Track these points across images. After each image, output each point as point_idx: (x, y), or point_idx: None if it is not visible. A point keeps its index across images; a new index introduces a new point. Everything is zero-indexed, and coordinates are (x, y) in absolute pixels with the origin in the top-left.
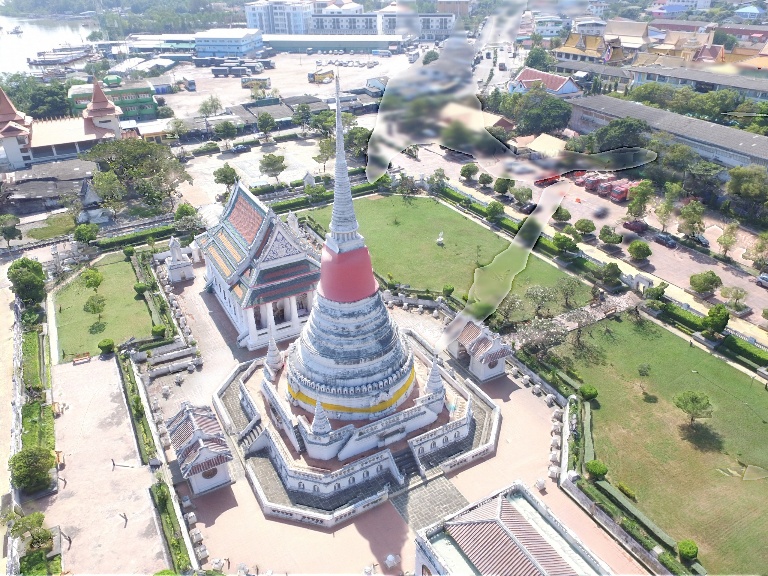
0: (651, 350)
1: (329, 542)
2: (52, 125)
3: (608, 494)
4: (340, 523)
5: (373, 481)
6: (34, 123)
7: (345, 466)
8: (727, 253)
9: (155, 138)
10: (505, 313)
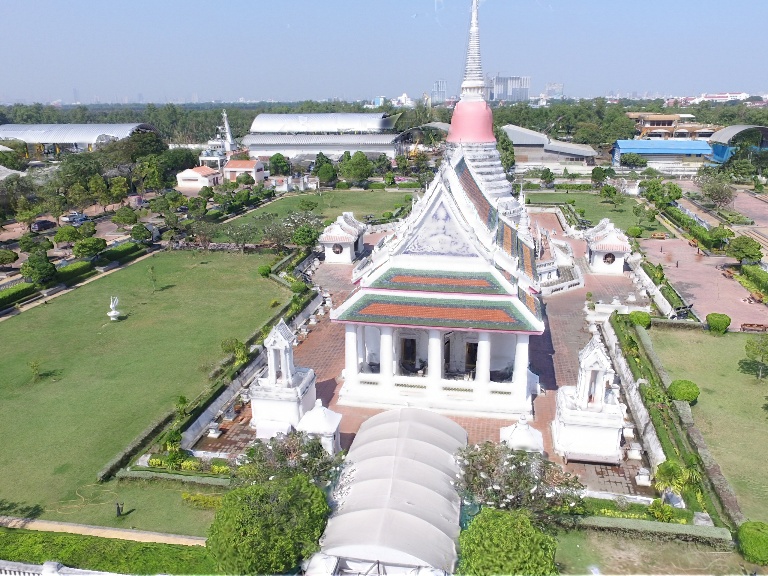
0: None
1: None
2: None
3: None
4: None
5: None
6: None
7: None
8: None
9: None
10: None
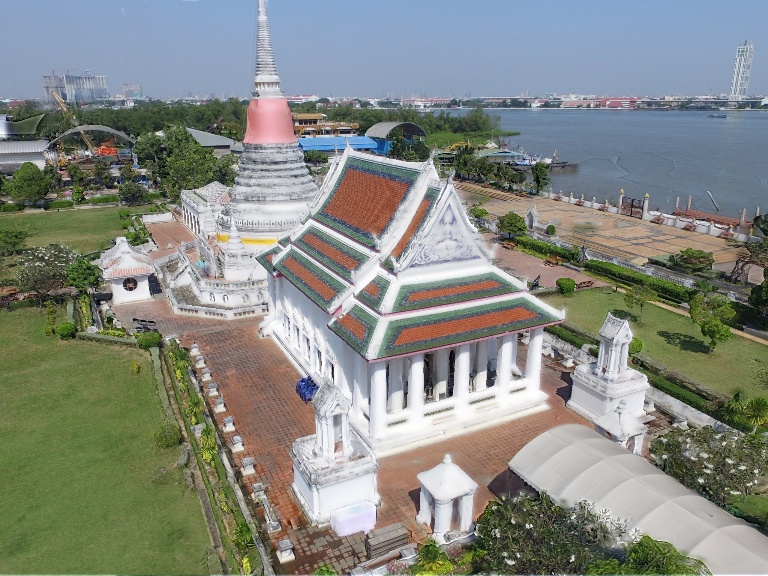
0: None
1: None
2: None
3: None
4: None
5: None
6: None
7: None
8: None
9: None
10: None
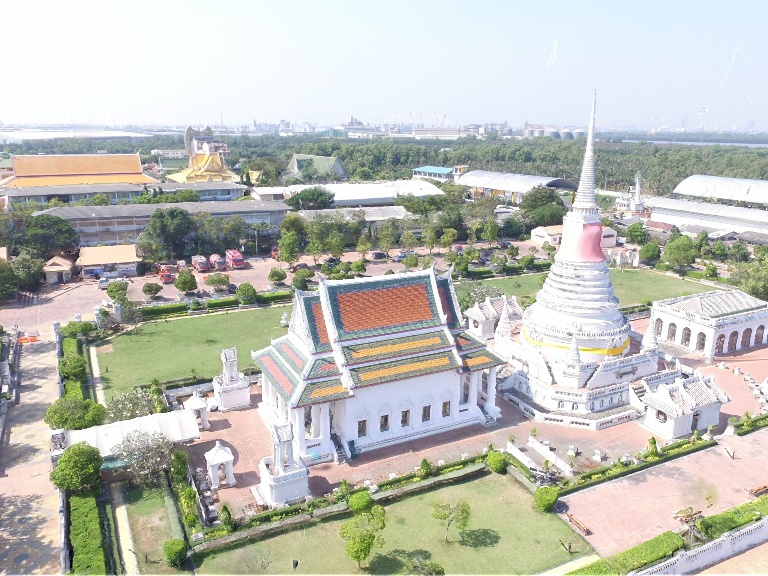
0: None
1: None
2: None
3: None
4: None
5: None
6: None
7: None
8: (365, 256)
9: None
10: None
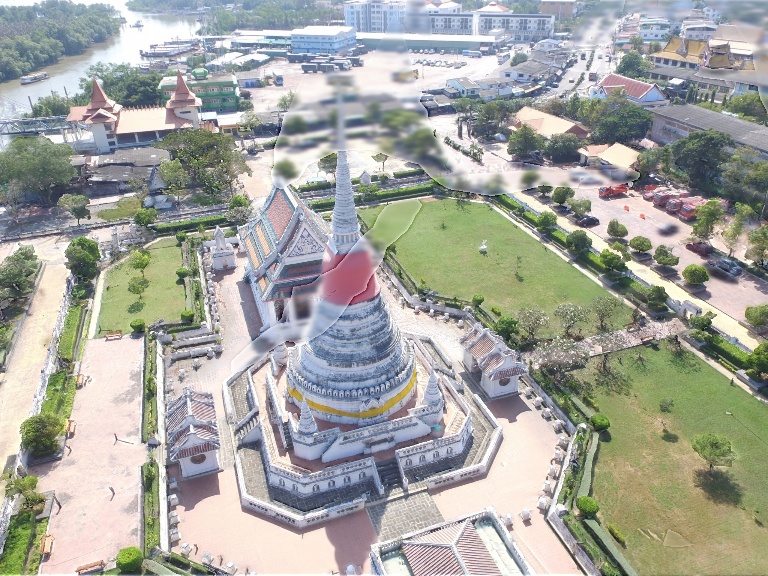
0: (684, 384)
1: (296, 543)
2: (138, 114)
3: (594, 535)
4: (312, 525)
5: (354, 487)
6: (122, 111)
7: (327, 469)
8: None
9: (232, 130)
10: (530, 329)
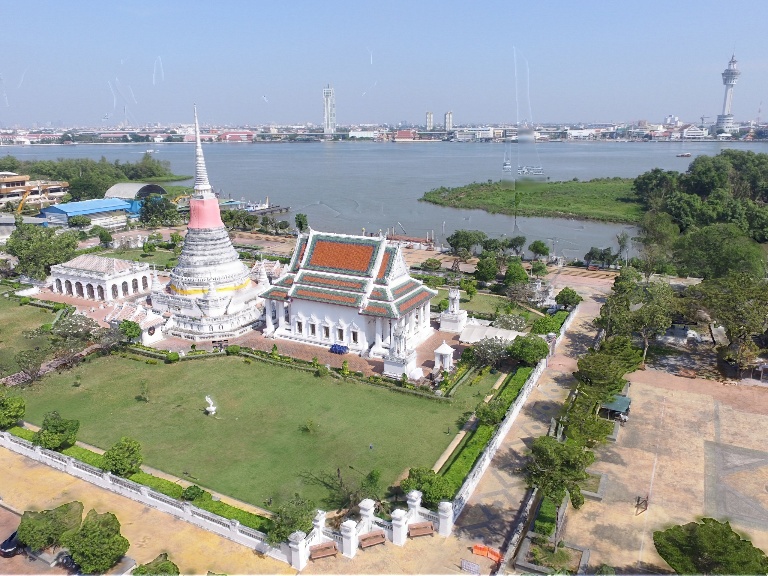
0: None
1: None
2: None
3: None
4: None
5: None
6: None
7: None
8: None
9: None
10: None
